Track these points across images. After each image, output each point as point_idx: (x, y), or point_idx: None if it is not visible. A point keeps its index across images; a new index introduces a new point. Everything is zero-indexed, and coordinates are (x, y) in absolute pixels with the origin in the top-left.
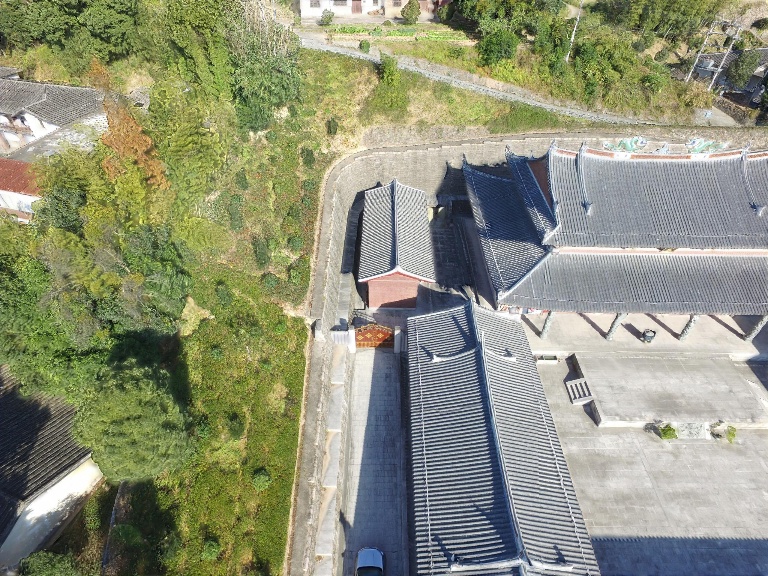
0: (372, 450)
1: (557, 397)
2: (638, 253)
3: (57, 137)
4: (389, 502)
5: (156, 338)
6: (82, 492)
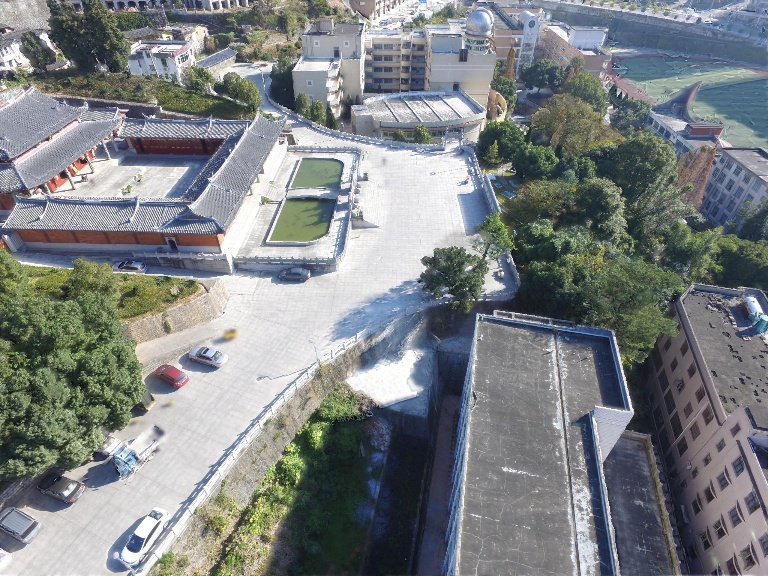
0: (68, 266)
1: None
2: (43, 147)
3: None
4: (98, 263)
5: None
6: None
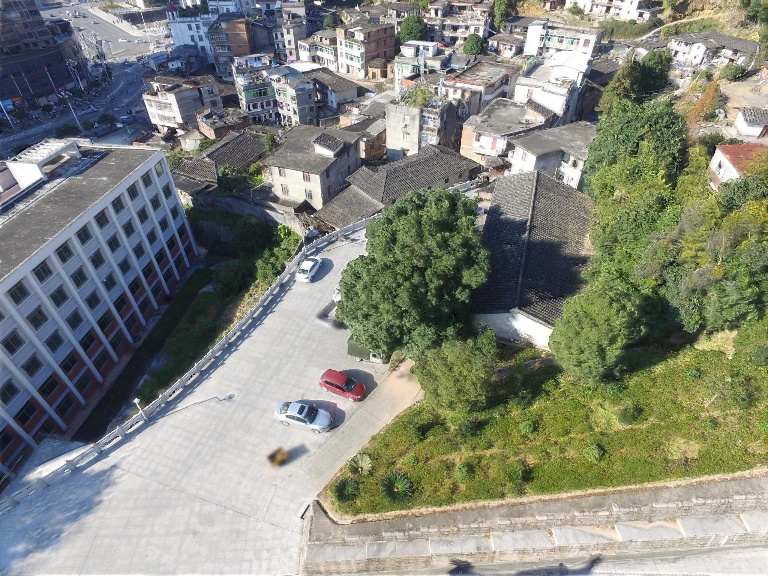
0: None
1: None
2: None
3: None
4: None
5: (673, 319)
6: (535, 343)
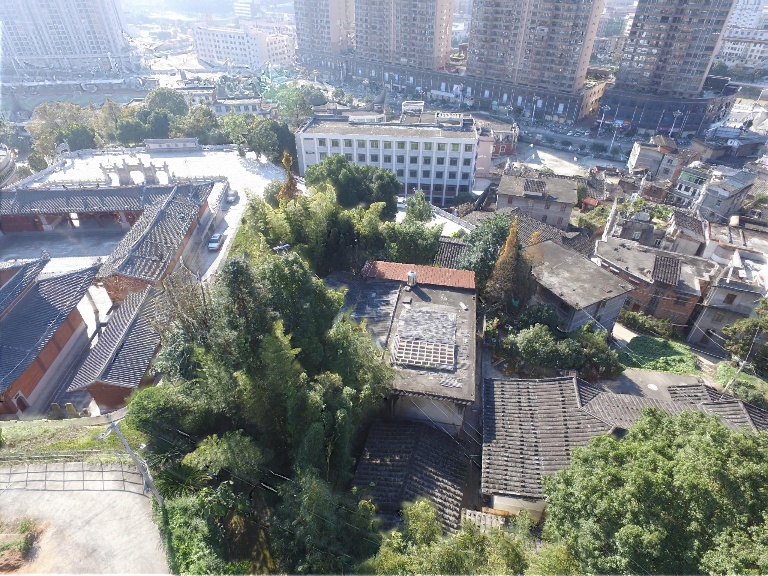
0: None
1: (92, 293)
2: None
3: (460, 326)
4: None
5: None
6: None
